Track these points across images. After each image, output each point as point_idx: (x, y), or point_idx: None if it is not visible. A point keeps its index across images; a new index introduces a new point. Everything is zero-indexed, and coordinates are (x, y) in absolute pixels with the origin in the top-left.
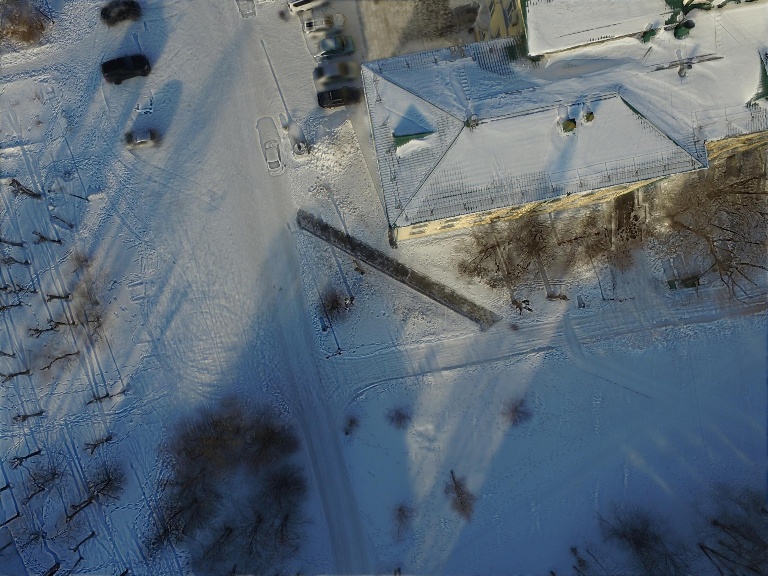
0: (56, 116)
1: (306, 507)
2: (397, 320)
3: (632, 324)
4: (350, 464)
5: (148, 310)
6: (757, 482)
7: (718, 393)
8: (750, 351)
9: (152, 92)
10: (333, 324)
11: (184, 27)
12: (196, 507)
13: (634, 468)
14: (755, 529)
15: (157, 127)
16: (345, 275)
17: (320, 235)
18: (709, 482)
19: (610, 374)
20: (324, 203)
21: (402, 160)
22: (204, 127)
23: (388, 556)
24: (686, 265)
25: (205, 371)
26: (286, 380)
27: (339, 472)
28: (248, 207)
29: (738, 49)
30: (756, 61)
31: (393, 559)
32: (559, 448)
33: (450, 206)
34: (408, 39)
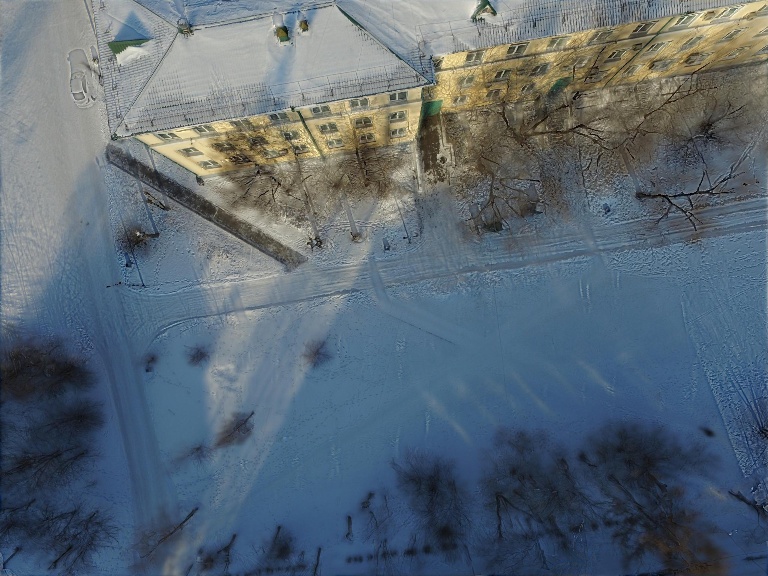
0: None
1: (105, 443)
2: (202, 258)
3: (438, 269)
4: (151, 402)
5: None
6: (558, 432)
7: (523, 341)
8: (557, 300)
9: None
10: (138, 260)
11: None
12: None
13: (435, 415)
14: (553, 480)
15: None
16: (150, 211)
17: (128, 170)
18: (510, 431)
19: (415, 319)
20: None
21: (123, 68)
22: (15, 58)
23: (187, 496)
24: None
25: (10, 304)
26: (91, 316)
27: (141, 410)
28: (57, 140)
29: None
30: None
31: (192, 499)
32: (361, 392)
33: (170, 117)
34: None
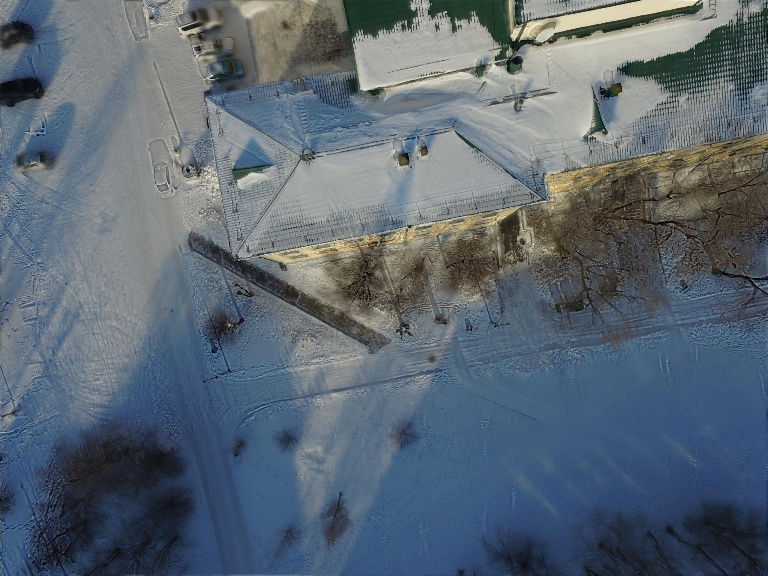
0: None
1: (195, 528)
2: (286, 342)
3: (520, 347)
4: (240, 485)
5: (40, 331)
6: (643, 505)
7: (605, 416)
8: (637, 374)
9: (45, 114)
10: (223, 346)
11: (78, 50)
12: (82, 528)
13: (521, 491)
14: (640, 553)
15: (50, 149)
16: (235, 297)
17: (211, 257)
18: (596, 505)
19: (498, 397)
20: (214, 225)
21: (243, 192)
22: (97, 149)
23: None
24: (573, 288)
25: (96, 392)
26: (177, 401)
27: (229, 493)
28: (140, 229)
29: (572, 84)
30: (589, 96)
31: None
32: (447, 470)
33: (291, 238)
34: (296, 63)
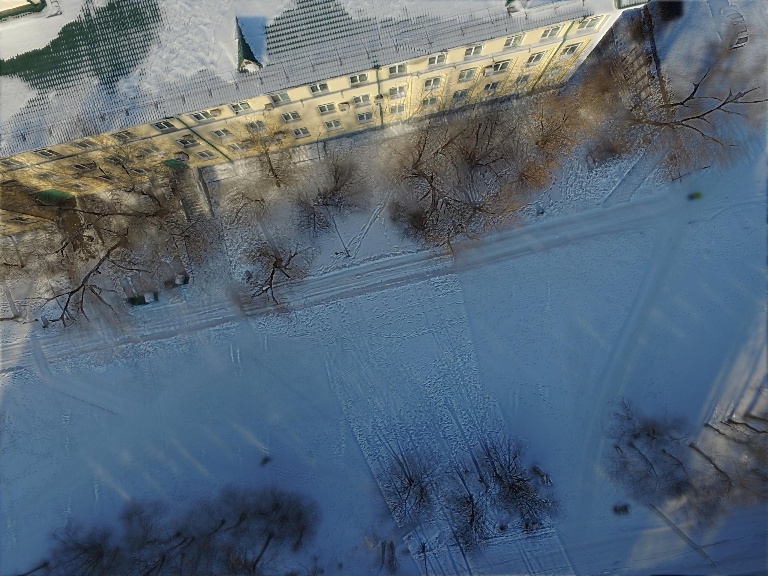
0: None
1: None
2: None
3: (97, 342)
4: None
5: None
6: (218, 494)
7: (180, 408)
8: (210, 365)
9: None
10: None
11: None
12: None
13: (102, 483)
14: (213, 540)
15: None
16: None
17: None
18: (173, 495)
19: (78, 392)
20: None
21: None
22: None
23: None
24: (143, 283)
25: None
26: None
27: None
28: None
29: None
30: None
31: None
32: (31, 465)
33: None
34: None
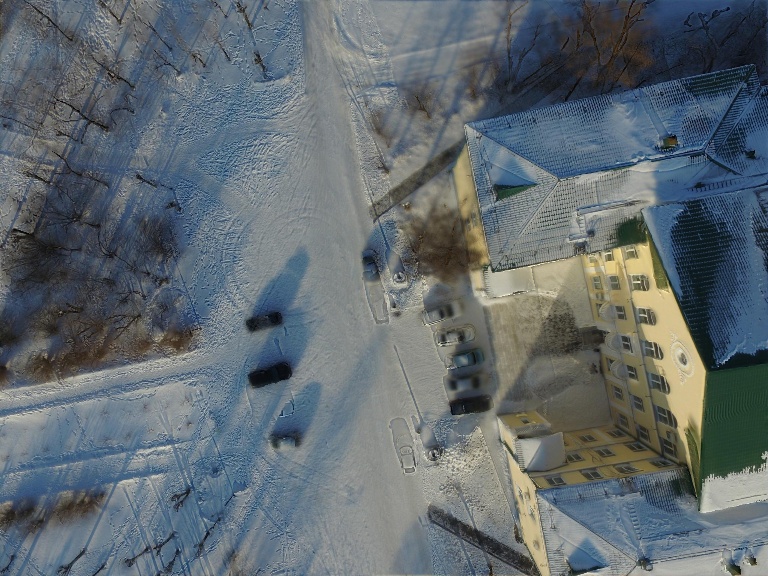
0: (204, 417)
1: None
2: None
3: None
4: None
5: None
6: None
7: None
8: None
9: (292, 394)
10: None
11: (322, 333)
12: None
13: None
14: None
15: (297, 426)
16: (474, 568)
17: (449, 528)
18: None
19: None
20: (454, 500)
21: None
22: (341, 427)
23: None
24: None
25: None
26: None
27: None
28: (382, 501)
29: None
30: None
31: None
32: None
33: None
34: (536, 354)
